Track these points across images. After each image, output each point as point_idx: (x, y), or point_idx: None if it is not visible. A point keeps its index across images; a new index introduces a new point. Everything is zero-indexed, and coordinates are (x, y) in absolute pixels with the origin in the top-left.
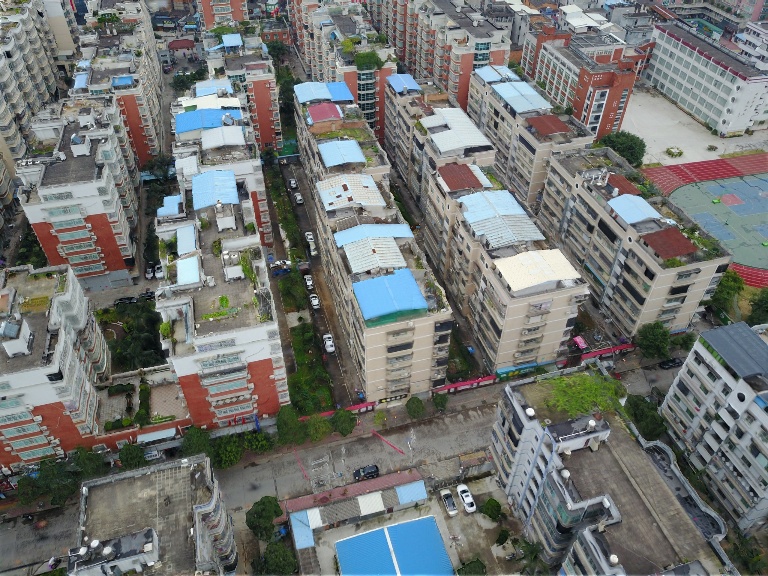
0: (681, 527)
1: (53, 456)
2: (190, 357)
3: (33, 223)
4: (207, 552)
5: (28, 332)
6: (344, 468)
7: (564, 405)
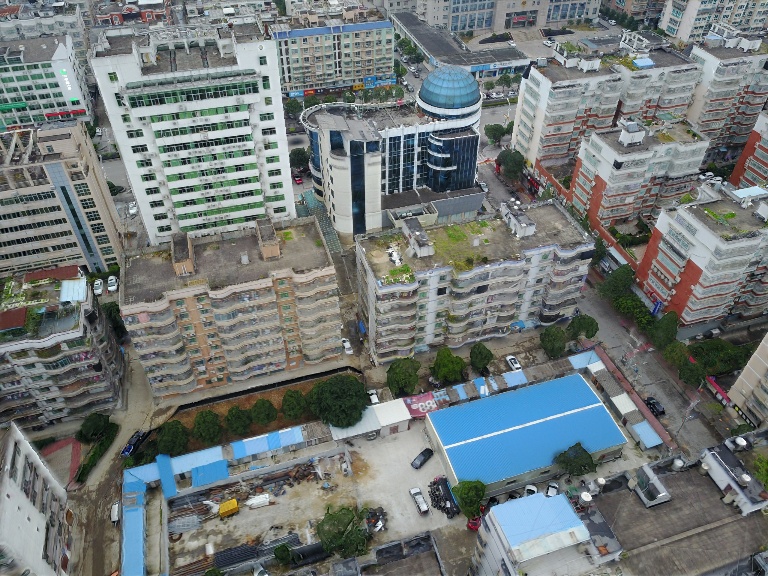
0: (663, 567)
1: (581, 214)
2: (669, 218)
3: (754, 130)
4: (537, 273)
5: (640, 139)
6: (653, 391)
7: (765, 468)
